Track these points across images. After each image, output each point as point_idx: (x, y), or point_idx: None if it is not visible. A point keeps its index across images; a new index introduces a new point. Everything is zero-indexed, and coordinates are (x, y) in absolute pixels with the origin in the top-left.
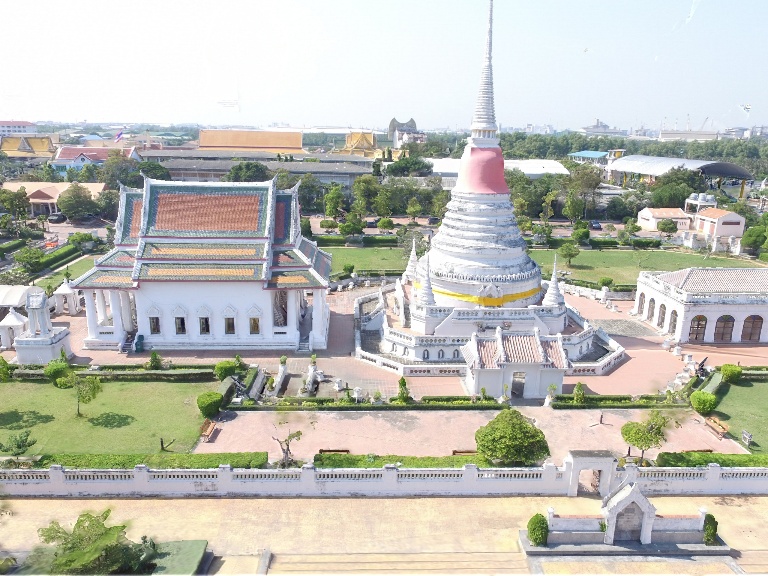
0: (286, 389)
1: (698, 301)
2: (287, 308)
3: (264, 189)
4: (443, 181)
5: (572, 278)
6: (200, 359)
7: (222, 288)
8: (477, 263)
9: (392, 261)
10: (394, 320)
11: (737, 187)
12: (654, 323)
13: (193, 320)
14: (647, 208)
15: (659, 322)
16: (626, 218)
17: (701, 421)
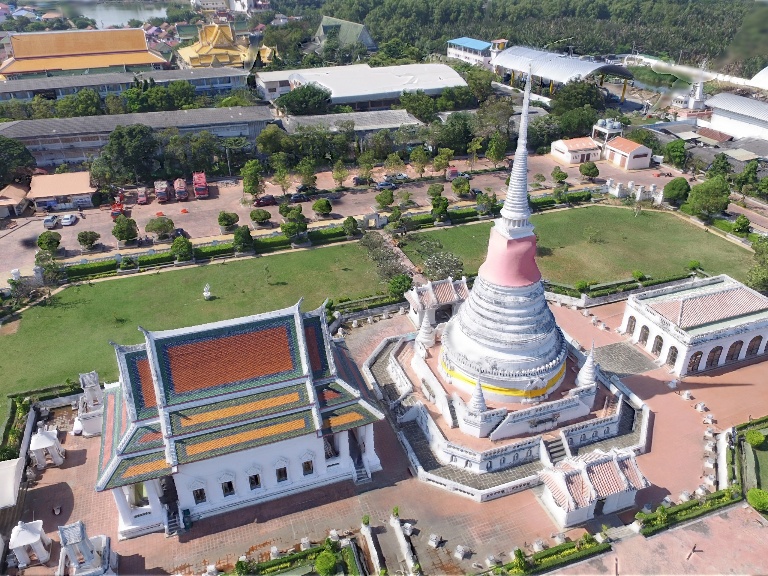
0: (384, 559)
1: (698, 341)
2: (340, 443)
3: (289, 317)
4: (351, 119)
5: (548, 283)
6: (264, 524)
7: (271, 444)
8: (520, 357)
9: (357, 272)
10: (435, 414)
11: (620, 86)
12: (648, 349)
13: (241, 480)
14: (562, 141)
15: (654, 349)
16: (540, 149)
17: (763, 522)
